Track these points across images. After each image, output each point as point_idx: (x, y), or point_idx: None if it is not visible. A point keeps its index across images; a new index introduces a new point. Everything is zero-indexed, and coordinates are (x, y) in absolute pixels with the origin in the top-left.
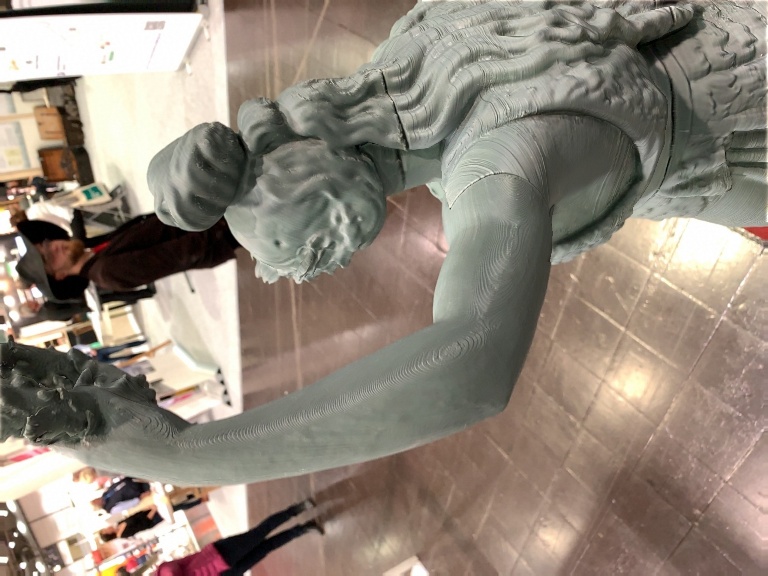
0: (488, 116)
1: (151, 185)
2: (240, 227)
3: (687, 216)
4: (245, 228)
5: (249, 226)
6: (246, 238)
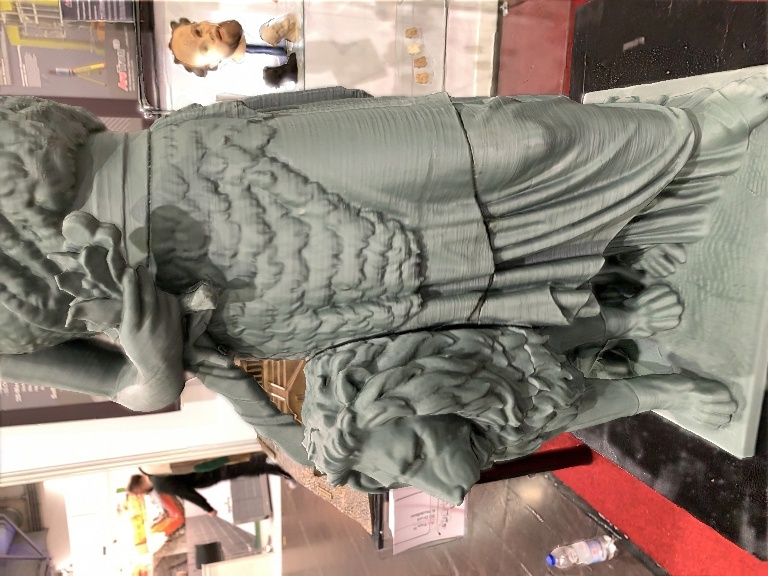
0: None
1: None
2: None
3: (255, 133)
4: None
5: None
6: None
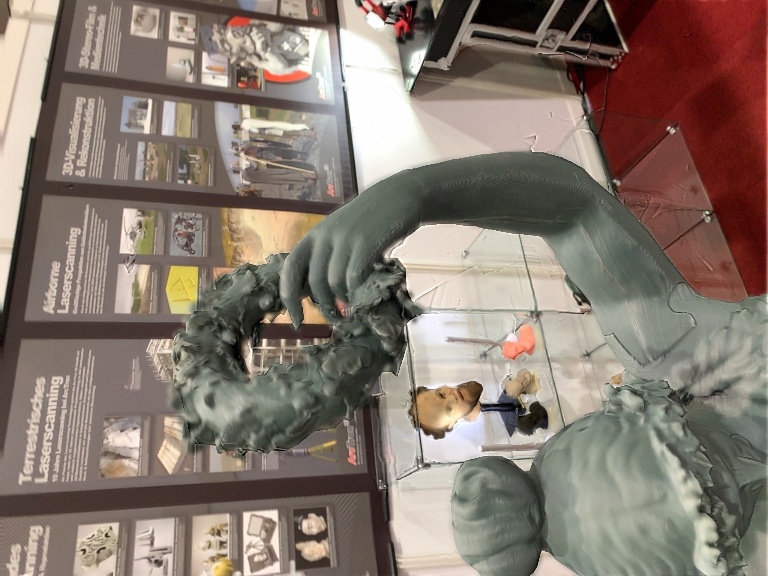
0: (623, 381)
1: (454, 524)
2: (560, 473)
3: None
4: (559, 464)
5: (555, 457)
6: (574, 466)
